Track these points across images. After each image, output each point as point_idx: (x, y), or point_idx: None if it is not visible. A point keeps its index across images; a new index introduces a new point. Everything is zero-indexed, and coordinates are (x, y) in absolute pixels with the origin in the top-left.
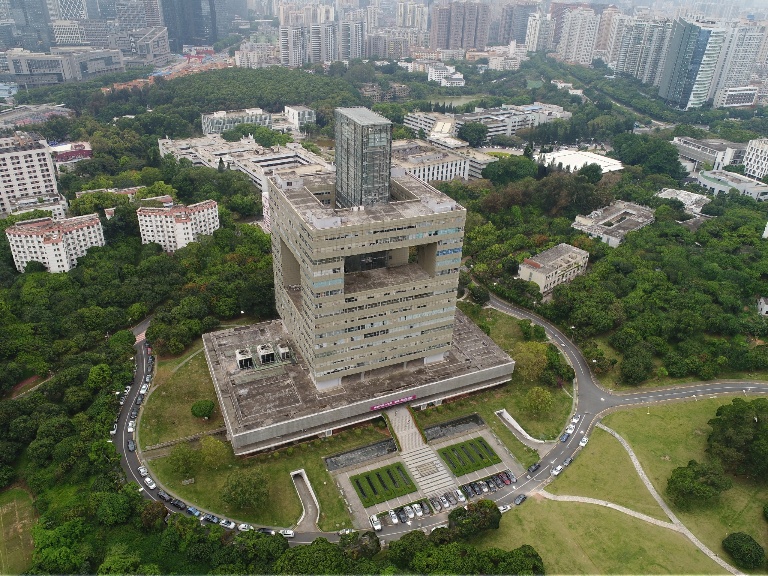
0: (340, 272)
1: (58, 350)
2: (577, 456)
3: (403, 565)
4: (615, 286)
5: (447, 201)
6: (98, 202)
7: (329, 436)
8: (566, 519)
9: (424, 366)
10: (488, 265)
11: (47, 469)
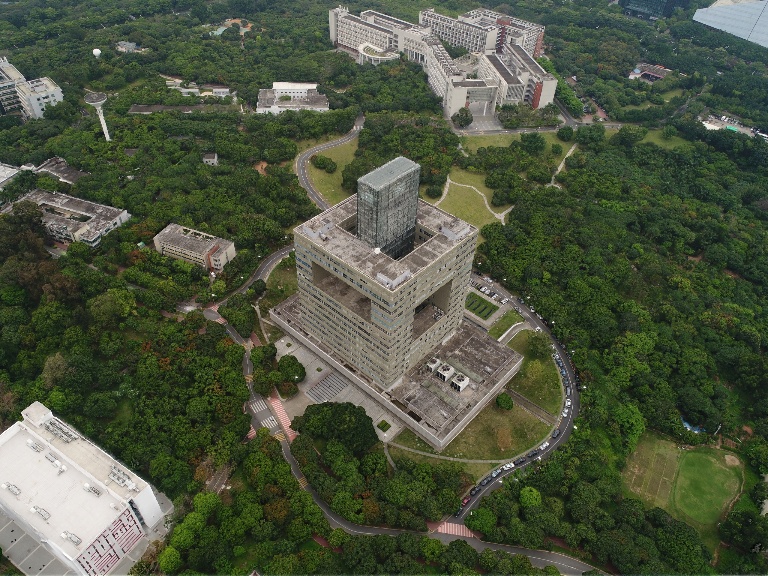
0: None
1: (532, 568)
2: None
3: None
4: None
5: None
6: None
7: None
8: None
9: None
10: None
11: (605, 480)
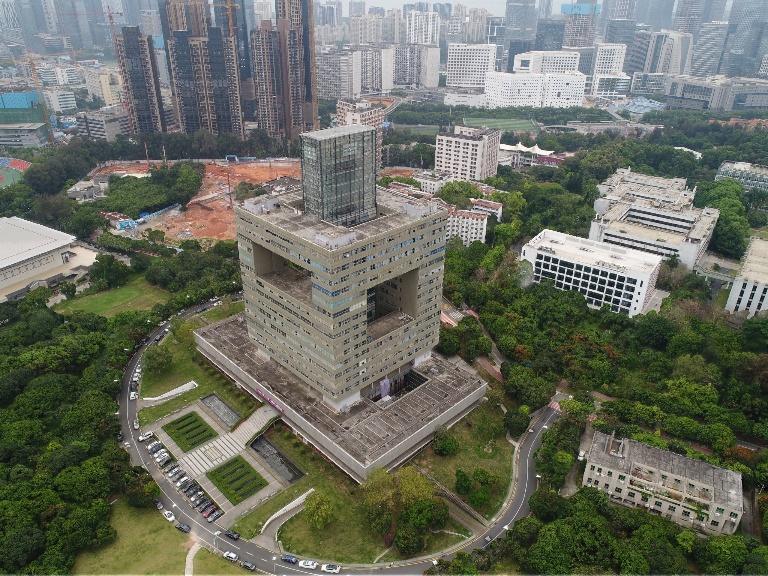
0: (252, 253)
1: None
2: (261, 575)
3: (93, 454)
4: (670, 568)
5: (328, 236)
6: (459, 190)
7: (238, 387)
8: (158, 569)
9: (320, 400)
10: (599, 415)
11: None
